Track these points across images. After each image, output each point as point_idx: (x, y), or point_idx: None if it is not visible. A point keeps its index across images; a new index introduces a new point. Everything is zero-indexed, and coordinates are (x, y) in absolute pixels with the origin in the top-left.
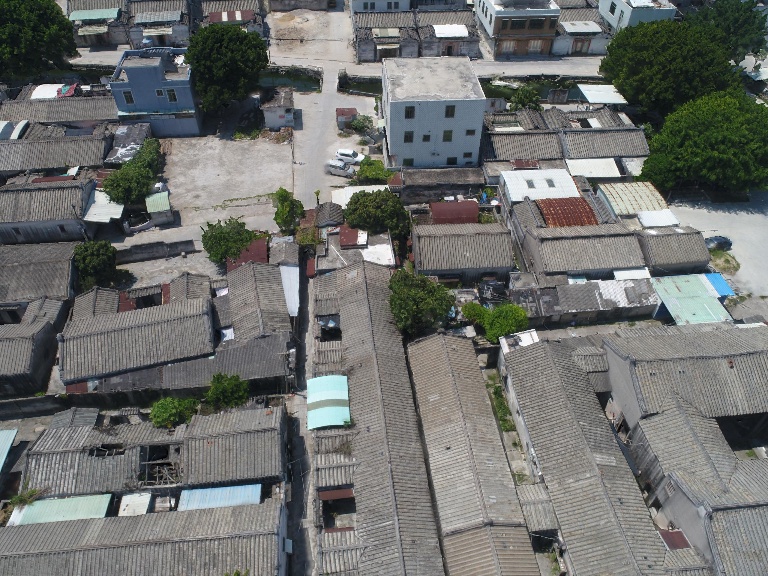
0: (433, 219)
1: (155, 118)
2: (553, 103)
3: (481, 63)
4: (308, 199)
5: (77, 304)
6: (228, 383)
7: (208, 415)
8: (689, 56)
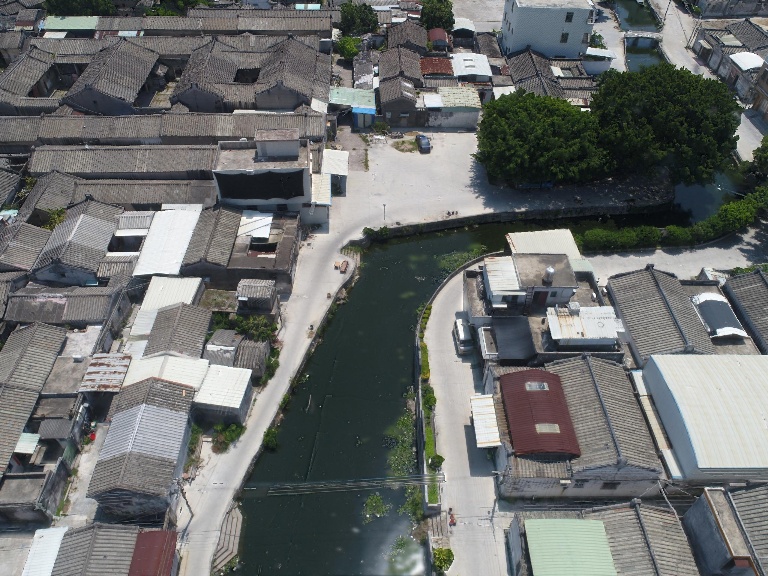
0: None
1: None
2: None
3: None
4: None
5: None
6: None
7: None
8: (624, 81)
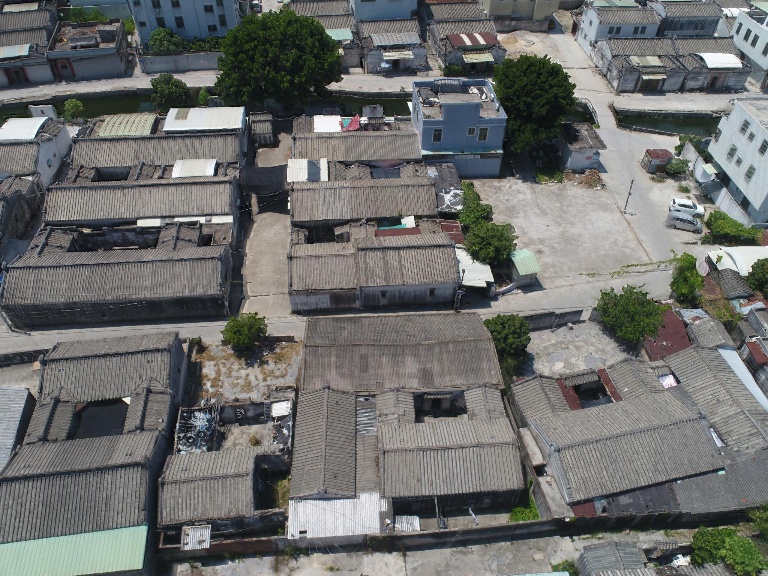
0: None
1: (459, 158)
2: None
3: (750, 96)
4: (667, 258)
5: (520, 394)
6: None
7: None
8: None
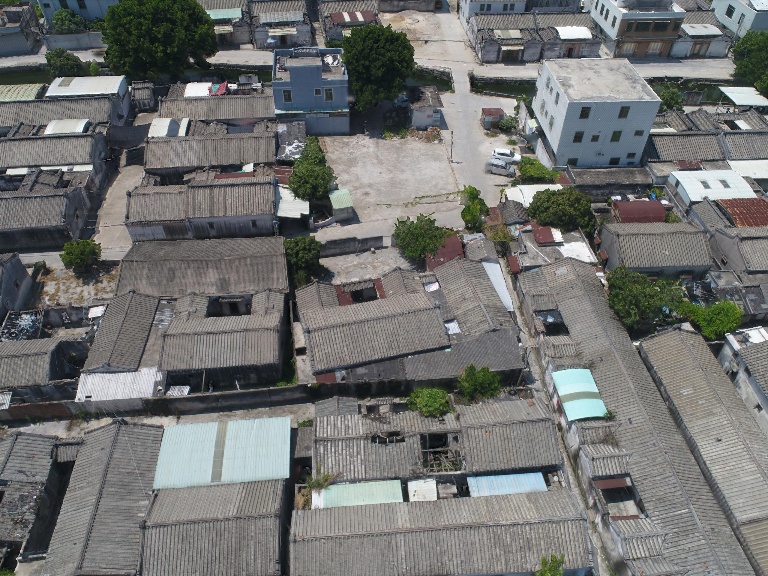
0: (621, 218)
1: (310, 116)
2: (686, 105)
3: None
4: None
5: (299, 297)
6: (483, 375)
7: (470, 405)
8: None
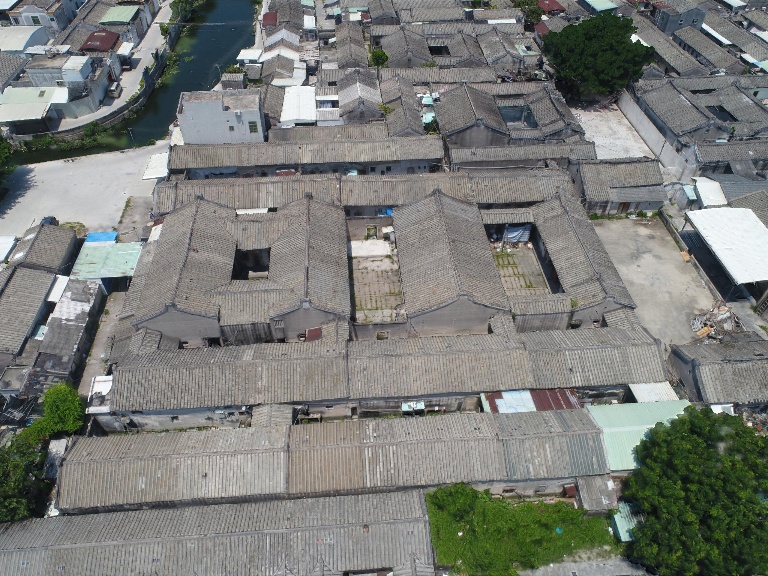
0: None
1: None
2: None
3: None
4: None
5: None
6: None
7: None
8: None
